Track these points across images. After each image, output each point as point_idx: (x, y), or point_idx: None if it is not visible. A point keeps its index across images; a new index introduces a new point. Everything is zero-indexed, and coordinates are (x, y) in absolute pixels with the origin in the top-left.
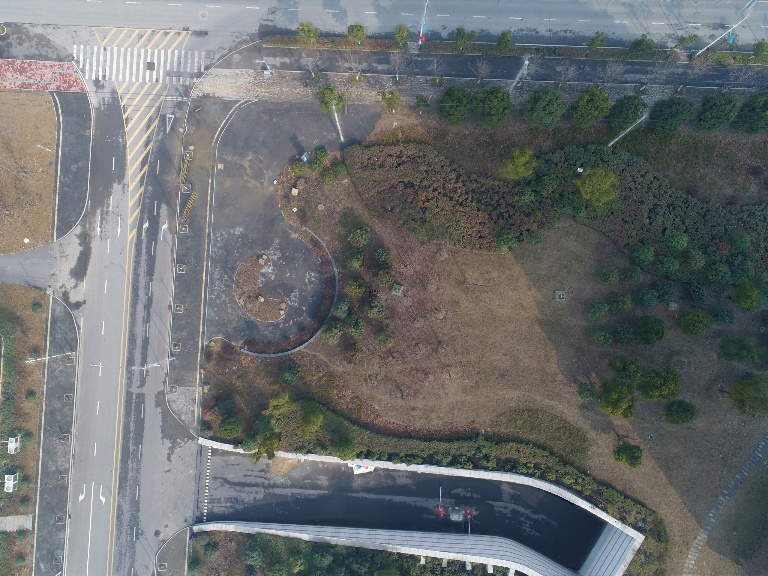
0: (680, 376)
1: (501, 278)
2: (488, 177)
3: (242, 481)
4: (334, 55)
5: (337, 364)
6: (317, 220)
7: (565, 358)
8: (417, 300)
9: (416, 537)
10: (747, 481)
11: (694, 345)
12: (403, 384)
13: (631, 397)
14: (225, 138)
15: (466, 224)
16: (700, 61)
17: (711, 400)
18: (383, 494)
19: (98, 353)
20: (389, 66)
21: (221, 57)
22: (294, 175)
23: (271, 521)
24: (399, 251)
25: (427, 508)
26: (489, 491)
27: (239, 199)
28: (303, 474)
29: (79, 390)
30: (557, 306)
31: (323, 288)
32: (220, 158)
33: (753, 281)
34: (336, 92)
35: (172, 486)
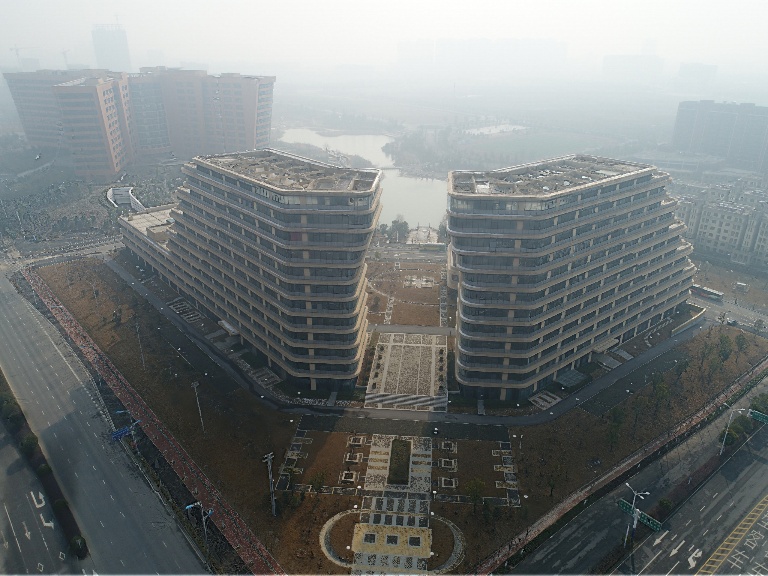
0: None
1: None
2: None
3: None
4: None
5: None
6: None
7: None
8: None
9: None
10: None
11: None
12: (96, 214)
13: None
14: None
15: None
16: None
17: None
18: None
19: None
20: None
21: None
22: None
23: None
24: None
25: None
26: None
27: None
28: None
29: None
30: None
31: None
32: None
33: None
34: None
35: None
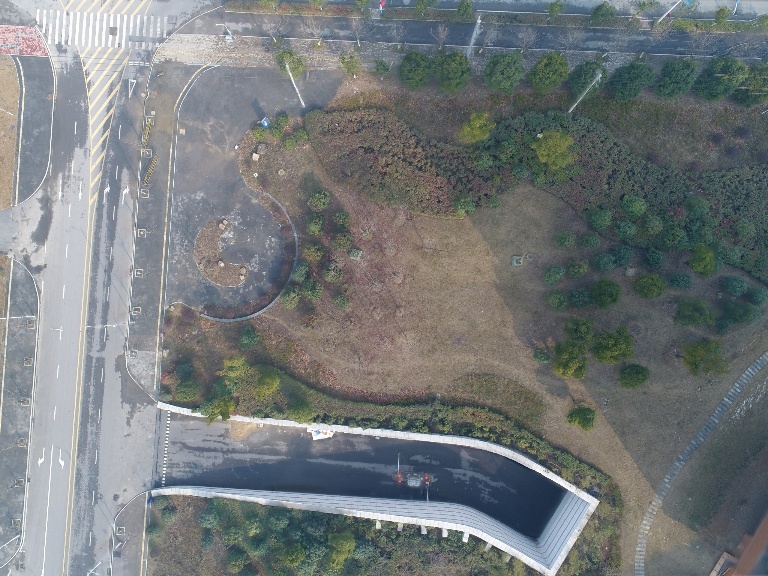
0: (637, 341)
1: (459, 243)
2: (448, 143)
3: (201, 446)
4: (296, 21)
5: (296, 329)
6: (277, 185)
7: (522, 323)
8: (375, 265)
9: (373, 503)
10: (703, 446)
11: (651, 310)
12: (361, 349)
13: (582, 358)
14: (187, 103)
15: (425, 189)
16: (662, 28)
17: (667, 365)
18: (342, 460)
19: (58, 317)
20: (351, 32)
21: (183, 22)
22: (255, 140)
23: (230, 486)
24: (358, 216)
25: (386, 474)
26: (448, 458)
27: (200, 164)
28: (262, 439)
29: (39, 354)
30: (515, 271)
31: (283, 254)
32: (182, 123)
33: (711, 247)
34: (298, 58)
35: (131, 450)
